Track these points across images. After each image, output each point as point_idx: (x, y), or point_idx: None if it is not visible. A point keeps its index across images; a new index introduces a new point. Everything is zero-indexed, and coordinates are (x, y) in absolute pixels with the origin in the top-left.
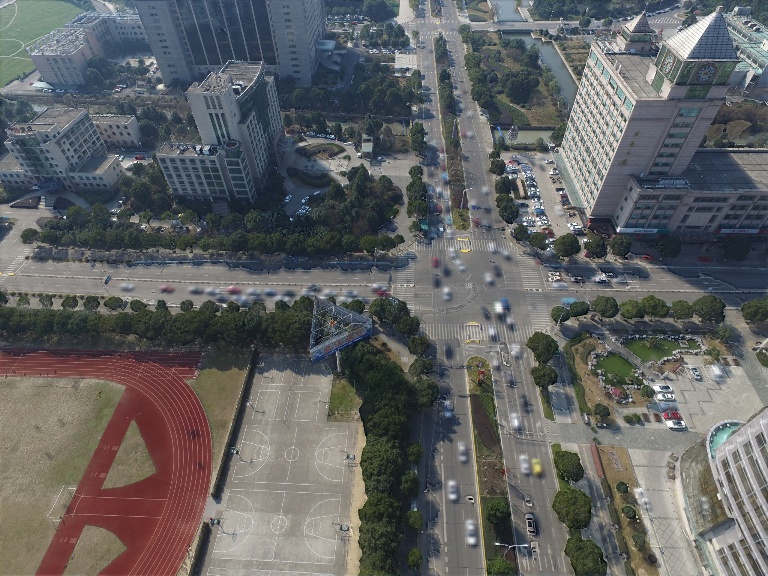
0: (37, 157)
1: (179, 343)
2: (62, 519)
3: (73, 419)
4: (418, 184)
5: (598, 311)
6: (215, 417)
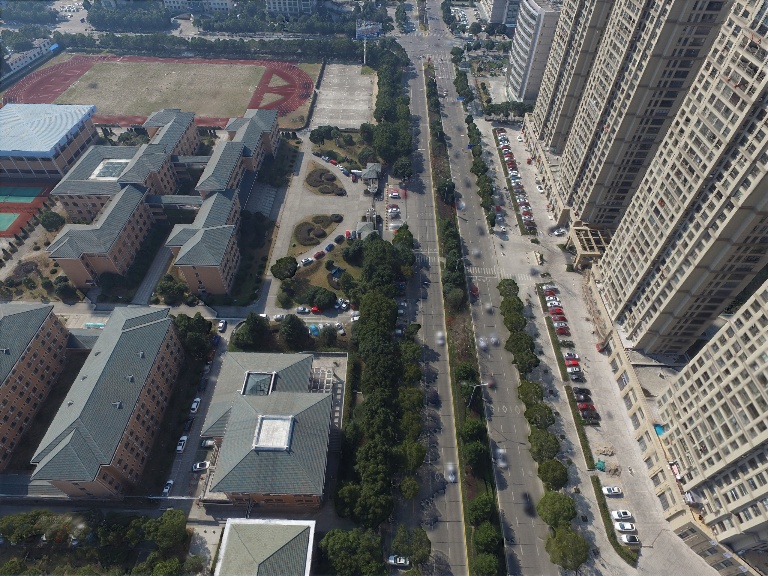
0: None
1: (287, 57)
2: (255, 91)
3: (247, 73)
4: None
5: (485, 46)
6: (311, 73)
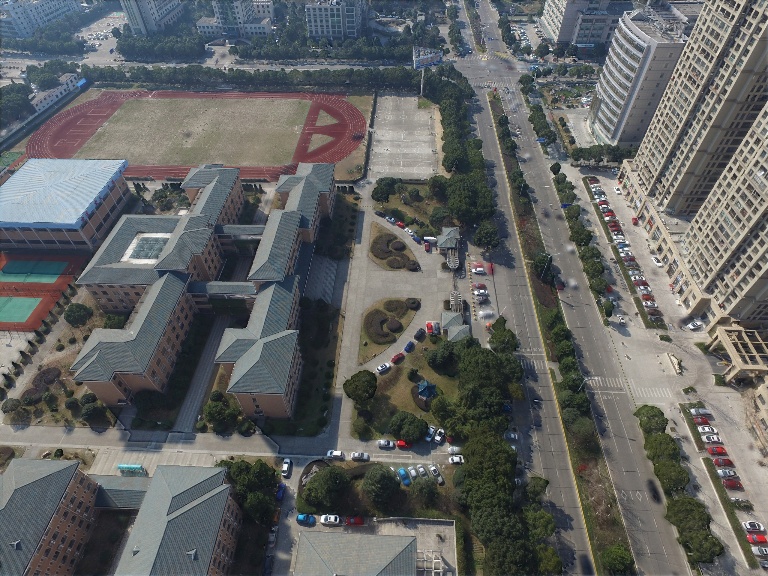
0: (227, 13)
1: (333, 89)
2: (301, 132)
3: (290, 109)
4: (456, 28)
5: (557, 72)
6: (362, 108)
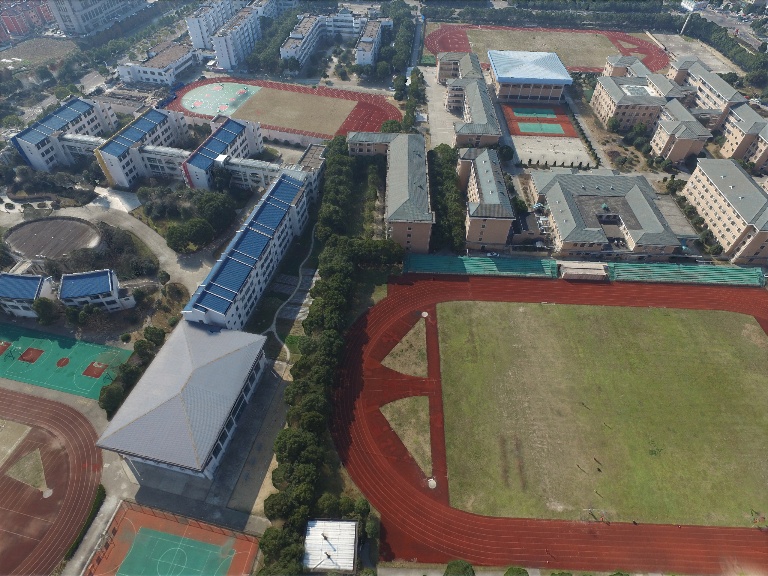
0: None
1: None
2: (620, 51)
3: None
4: None
5: None
6: None
